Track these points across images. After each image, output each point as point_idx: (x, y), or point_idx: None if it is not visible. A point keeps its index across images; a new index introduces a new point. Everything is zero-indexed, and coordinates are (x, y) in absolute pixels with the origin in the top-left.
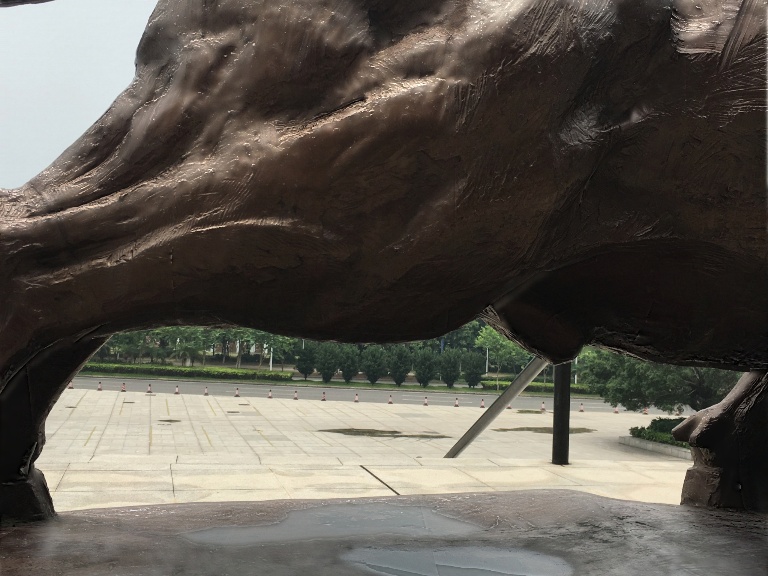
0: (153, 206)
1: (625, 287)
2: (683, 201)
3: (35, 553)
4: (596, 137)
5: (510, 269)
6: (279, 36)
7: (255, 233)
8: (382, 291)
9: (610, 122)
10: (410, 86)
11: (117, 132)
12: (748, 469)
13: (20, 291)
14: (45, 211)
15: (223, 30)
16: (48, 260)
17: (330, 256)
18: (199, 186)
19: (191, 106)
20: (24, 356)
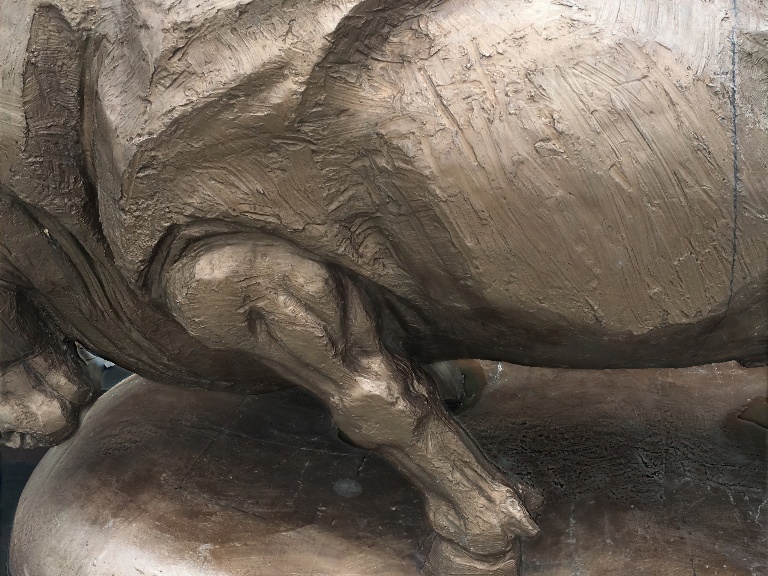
0: None
1: None
2: None
3: None
4: None
5: None
6: None
7: None
8: None
9: None
10: None
11: None
12: None
13: None
14: None
15: None
16: None
17: None
18: None
19: None
20: None
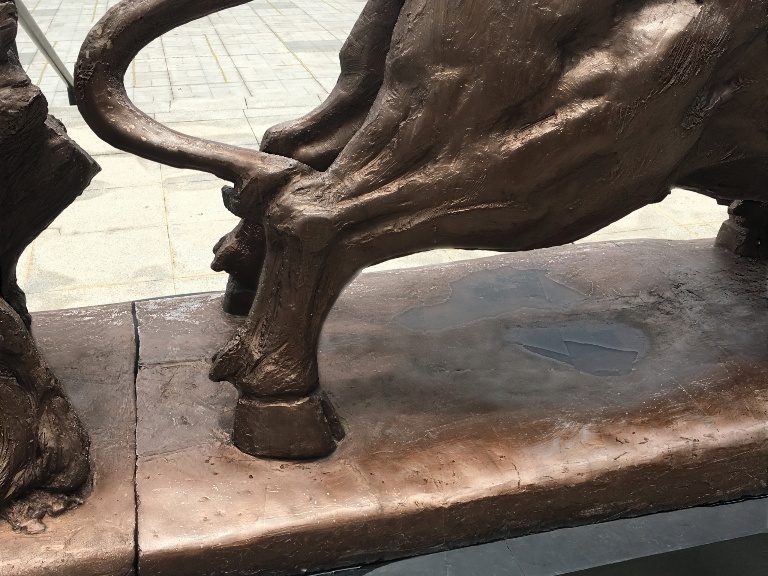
0: (421, 195)
1: (705, 173)
2: (756, 132)
3: (322, 348)
4: (705, 115)
5: (638, 206)
6: (499, 75)
7: (488, 213)
8: (559, 230)
9: (715, 94)
10: (587, 108)
11: (387, 136)
12: (767, 231)
13: (344, 250)
14: (350, 196)
15: (458, 66)
16: (356, 227)
17: (531, 220)
18: (451, 183)
19: (440, 125)
20: (347, 283)
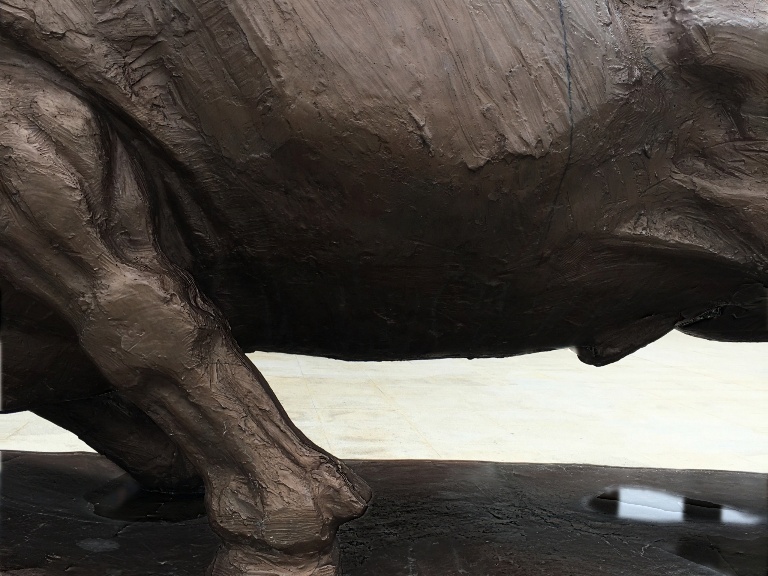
0: None
1: None
2: None
3: None
4: None
5: None
6: None
7: None
8: None
9: None
10: None
11: None
12: None
13: None
14: None
15: None
16: None
17: None
18: None
19: None
20: None
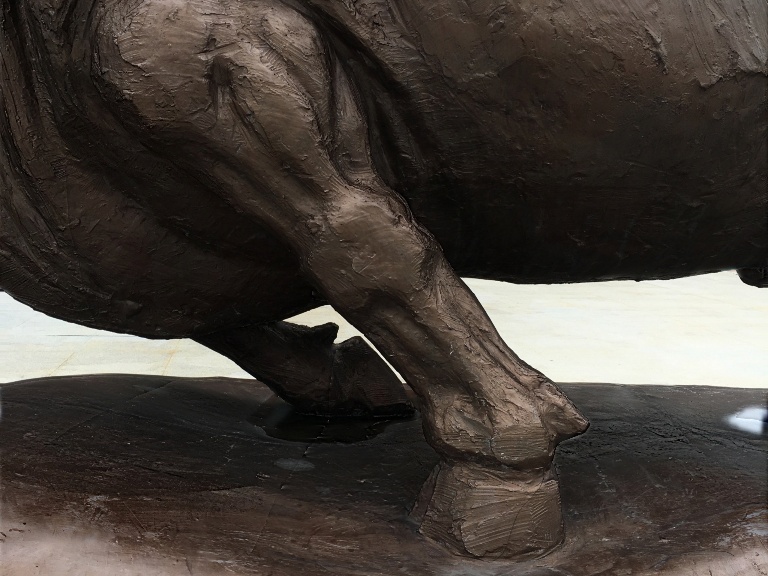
0: None
1: None
2: None
3: None
4: None
5: None
6: None
7: None
8: None
9: None
10: None
11: None
12: None
13: None
14: None
15: None
16: None
17: None
18: None
19: None
20: None
